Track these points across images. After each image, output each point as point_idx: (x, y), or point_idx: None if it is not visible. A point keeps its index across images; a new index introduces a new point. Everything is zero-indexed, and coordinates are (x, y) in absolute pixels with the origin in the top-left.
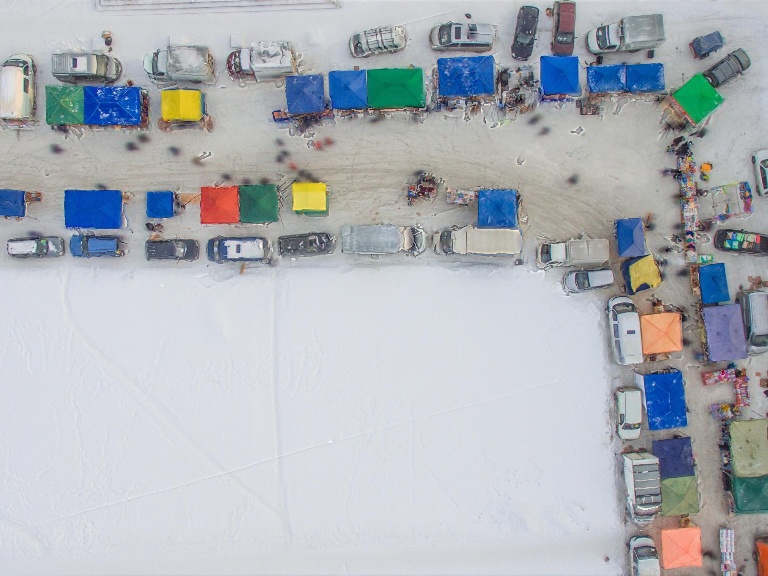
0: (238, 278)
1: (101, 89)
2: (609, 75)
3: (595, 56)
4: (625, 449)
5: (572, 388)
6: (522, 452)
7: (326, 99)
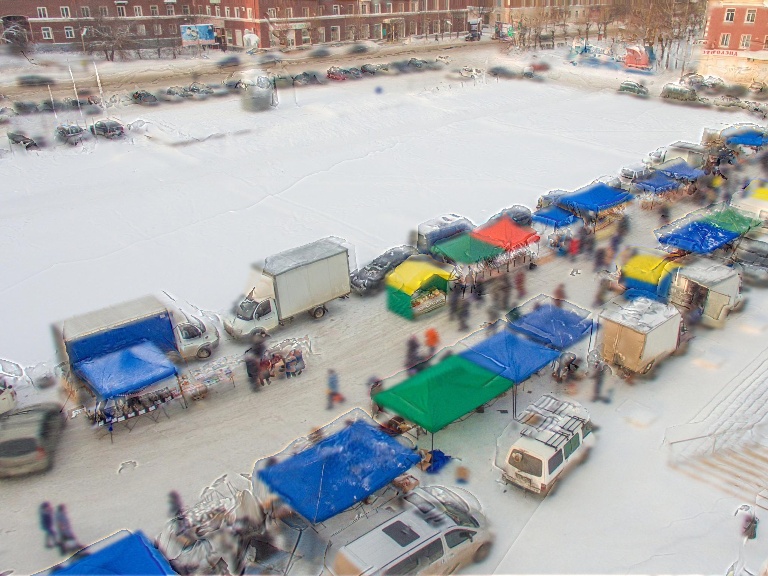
0: None
1: (720, 228)
2: None
3: None
4: None
5: None
6: None
7: None
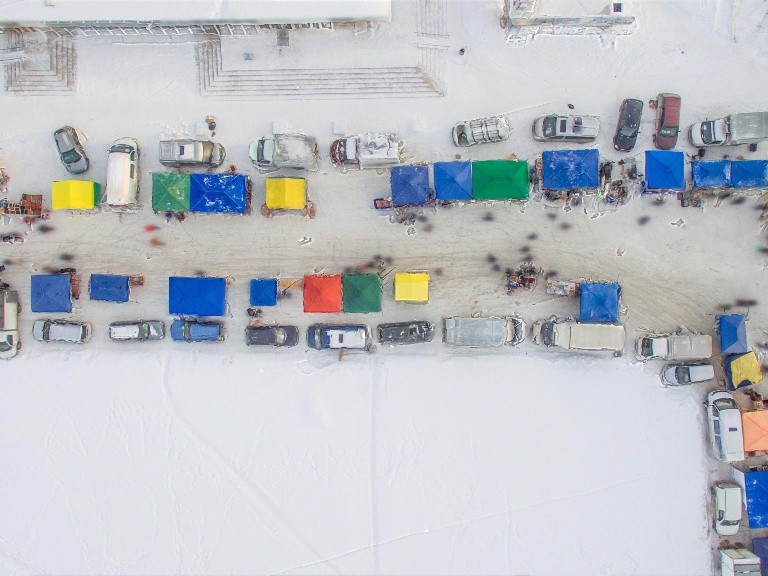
0: (337, 365)
1: (207, 177)
2: (715, 172)
3: (697, 148)
4: (721, 543)
5: (670, 482)
6: (618, 545)
7: (430, 190)
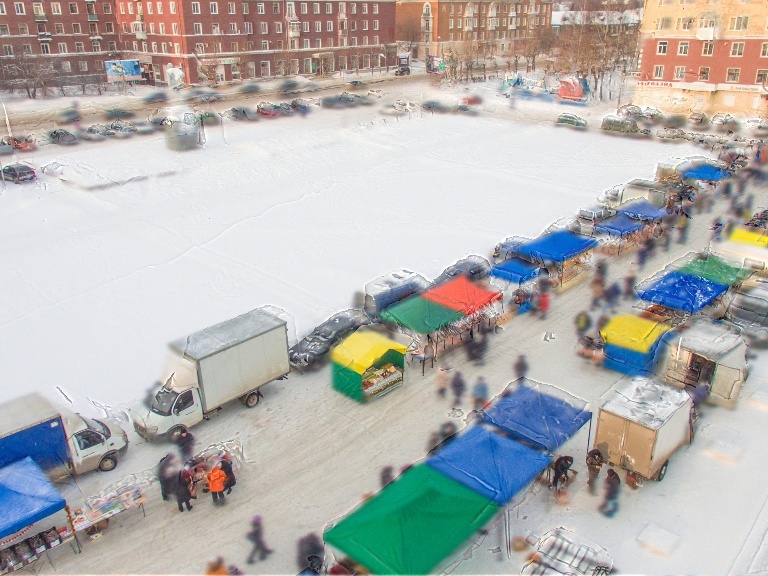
0: None
1: (709, 282)
2: None
3: None
4: None
5: None
6: None
7: None
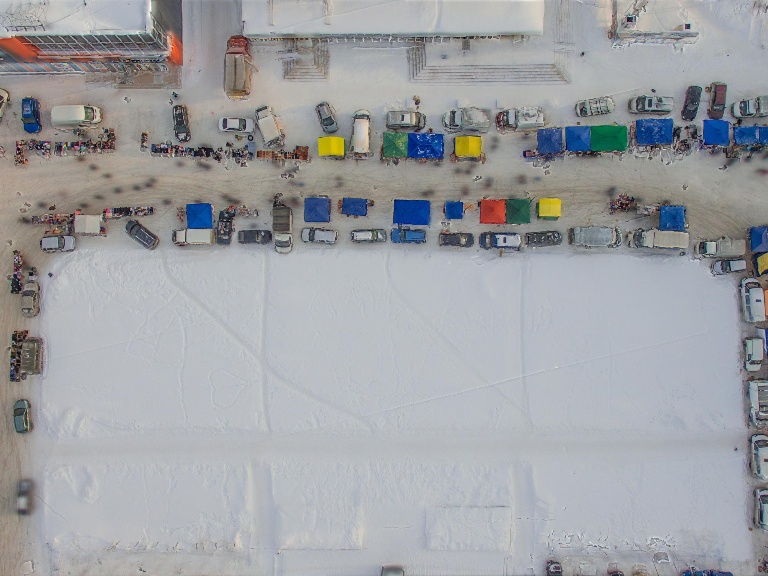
0: (499, 259)
1: (419, 135)
2: (749, 133)
3: (737, 119)
4: (749, 378)
5: (716, 337)
6: (682, 378)
7: (563, 144)
